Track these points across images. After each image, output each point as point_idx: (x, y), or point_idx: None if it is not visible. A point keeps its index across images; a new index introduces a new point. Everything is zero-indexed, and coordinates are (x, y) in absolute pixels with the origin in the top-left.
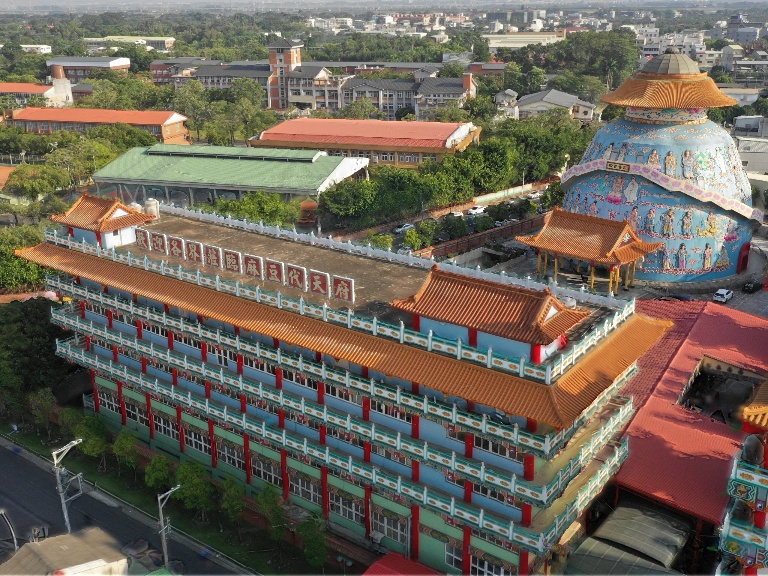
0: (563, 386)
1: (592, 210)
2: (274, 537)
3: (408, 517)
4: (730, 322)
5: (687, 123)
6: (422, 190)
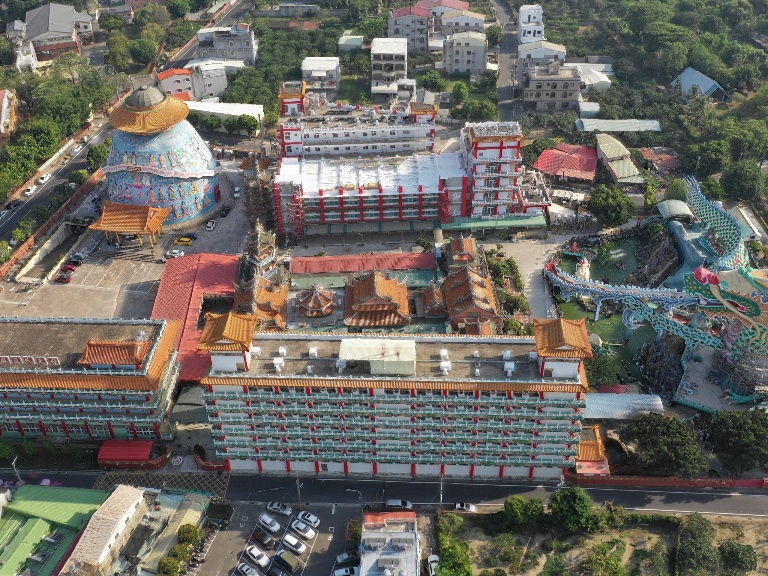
0: (151, 373)
1: (127, 193)
2: (55, 454)
3: (106, 425)
4: (213, 265)
5: (165, 131)
6: (3, 184)
